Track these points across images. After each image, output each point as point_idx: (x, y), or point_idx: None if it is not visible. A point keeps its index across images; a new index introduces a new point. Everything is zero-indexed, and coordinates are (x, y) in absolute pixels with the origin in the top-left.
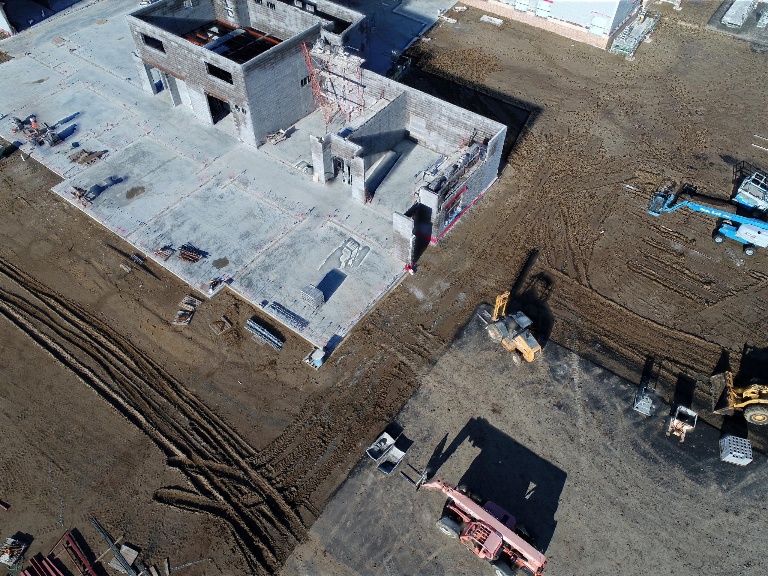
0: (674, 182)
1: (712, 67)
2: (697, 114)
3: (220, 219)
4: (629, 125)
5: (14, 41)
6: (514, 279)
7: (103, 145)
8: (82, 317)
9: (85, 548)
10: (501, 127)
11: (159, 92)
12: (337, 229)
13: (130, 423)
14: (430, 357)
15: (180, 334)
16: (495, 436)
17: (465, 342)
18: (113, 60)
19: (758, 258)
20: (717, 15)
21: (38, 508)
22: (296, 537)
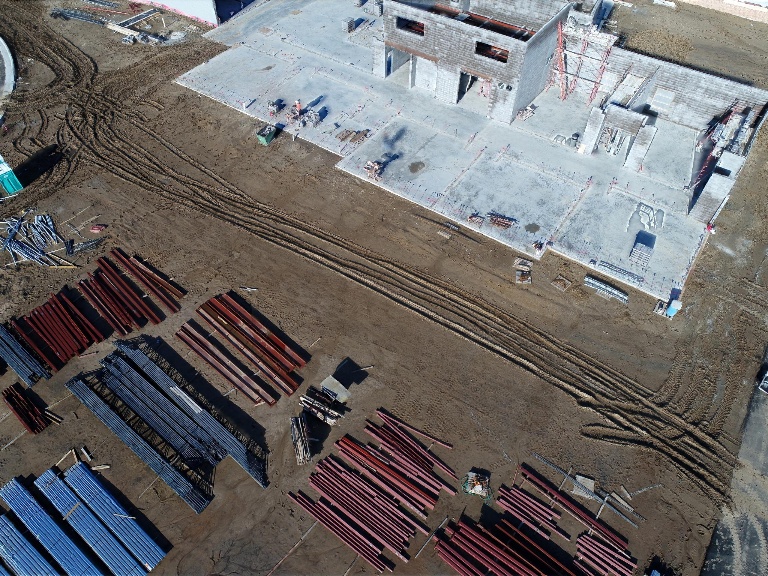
0: None
1: None
2: None
3: (510, 189)
4: None
5: (222, 32)
6: None
7: (362, 125)
8: (426, 279)
9: (543, 479)
10: None
11: (388, 75)
12: (624, 195)
13: (524, 370)
14: None
15: (528, 292)
16: None
17: None
18: (327, 47)
19: None
20: None
21: (479, 446)
22: (729, 464)
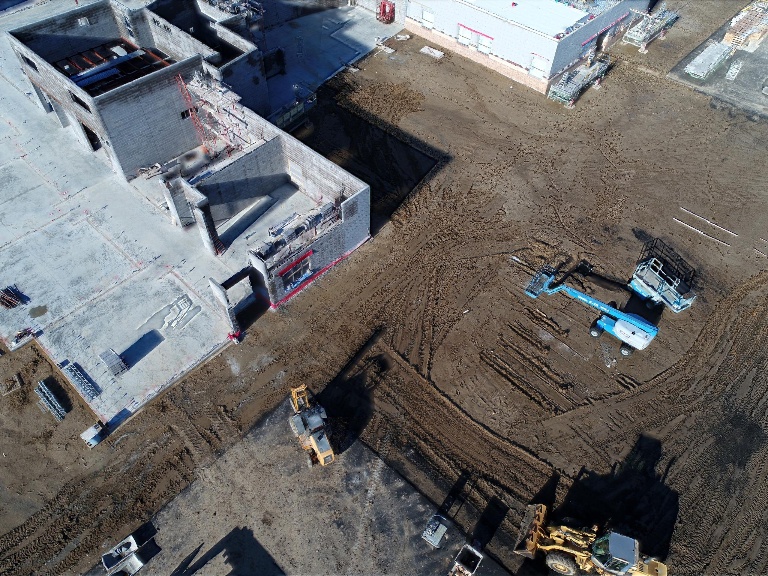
0: (570, 257)
1: (659, 123)
2: (624, 177)
3: (58, 260)
4: (542, 185)
5: None
6: (347, 360)
7: None
8: None
9: None
10: (364, 186)
11: (53, 110)
12: (175, 283)
13: None
14: (219, 446)
15: None
16: (254, 553)
17: (263, 432)
18: None
19: (634, 360)
20: (684, 62)
21: None
22: None
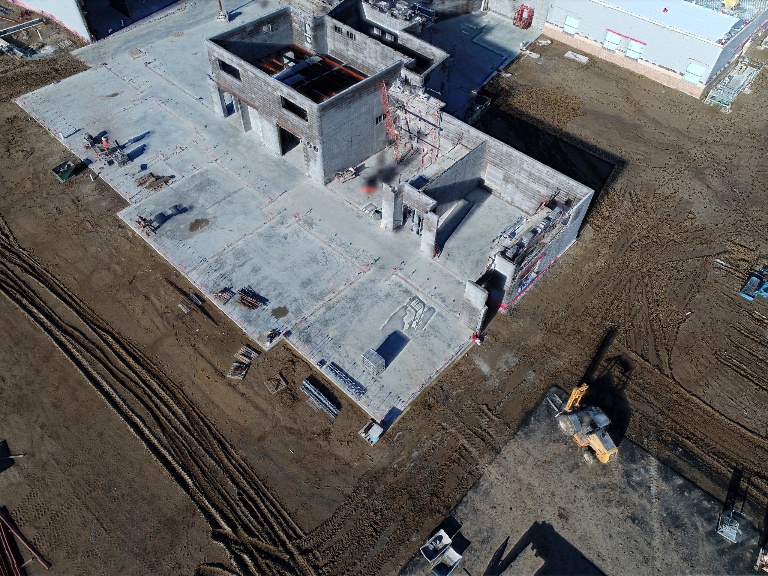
0: None
1: None
2: None
3: (282, 262)
4: (722, 189)
5: (92, 50)
6: (589, 360)
7: (171, 169)
8: (137, 359)
9: None
10: (588, 191)
11: (230, 115)
12: (402, 285)
13: (177, 485)
14: (493, 443)
15: (234, 389)
16: (560, 546)
17: (532, 430)
18: (187, 77)
19: None
20: None
21: (79, 571)
22: None
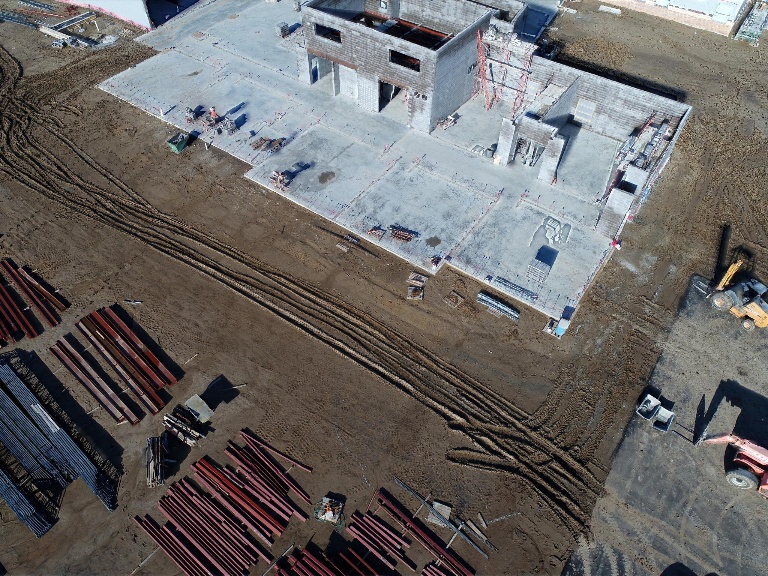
0: None
1: None
2: None
3: (418, 201)
4: None
5: (155, 36)
6: (716, 252)
7: (279, 133)
8: (317, 294)
9: (399, 505)
10: (686, 108)
11: (314, 82)
12: (533, 208)
13: (400, 391)
14: (662, 325)
15: (418, 308)
16: (750, 396)
17: (691, 311)
18: (258, 53)
19: None
20: None
21: (340, 470)
22: (594, 491)
